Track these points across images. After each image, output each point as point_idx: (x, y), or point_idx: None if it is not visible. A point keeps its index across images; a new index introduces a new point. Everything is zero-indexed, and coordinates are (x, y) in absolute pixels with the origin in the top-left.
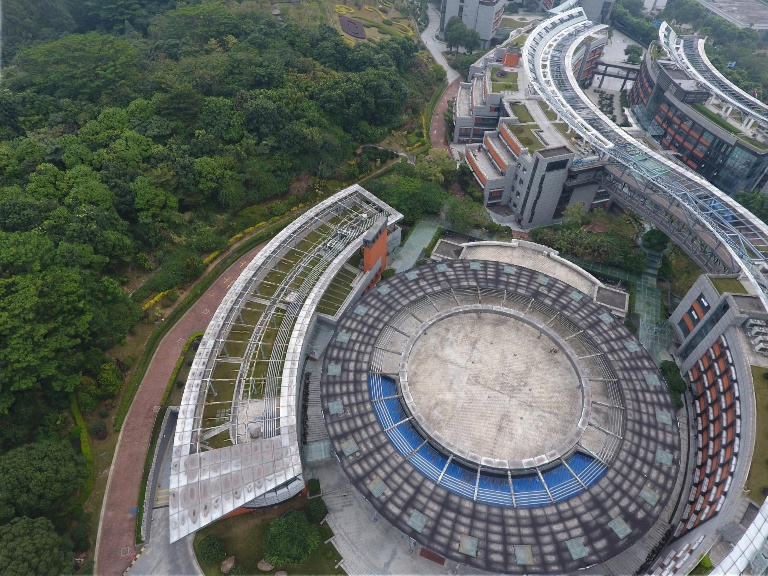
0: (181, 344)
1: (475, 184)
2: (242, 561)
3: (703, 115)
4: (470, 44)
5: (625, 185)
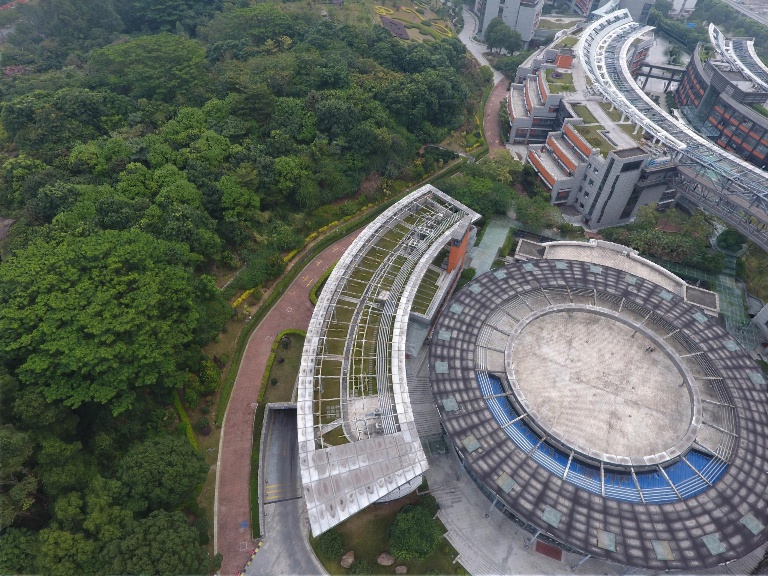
0: (269, 342)
1: (541, 184)
2: (360, 556)
3: (765, 116)
4: (512, 45)
5: (698, 186)
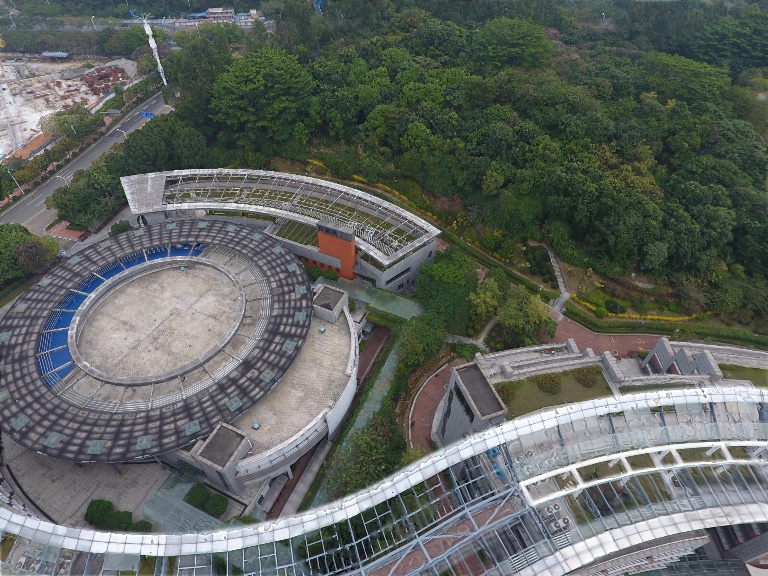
0: None
1: None
2: None
3: None
4: None
5: None
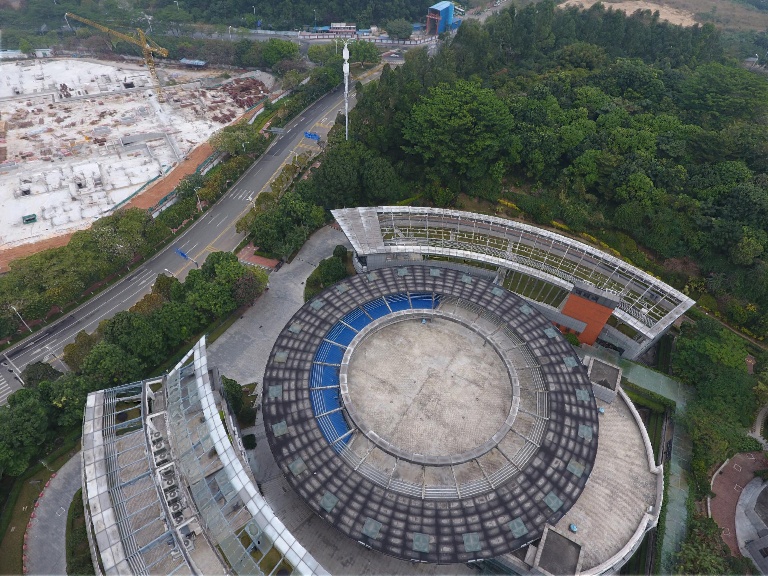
0: None
1: None
2: None
3: None
4: None
5: None
